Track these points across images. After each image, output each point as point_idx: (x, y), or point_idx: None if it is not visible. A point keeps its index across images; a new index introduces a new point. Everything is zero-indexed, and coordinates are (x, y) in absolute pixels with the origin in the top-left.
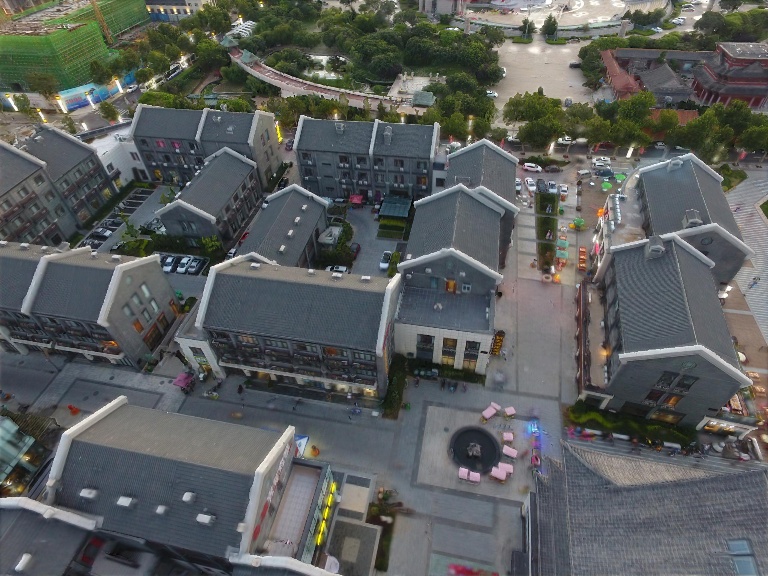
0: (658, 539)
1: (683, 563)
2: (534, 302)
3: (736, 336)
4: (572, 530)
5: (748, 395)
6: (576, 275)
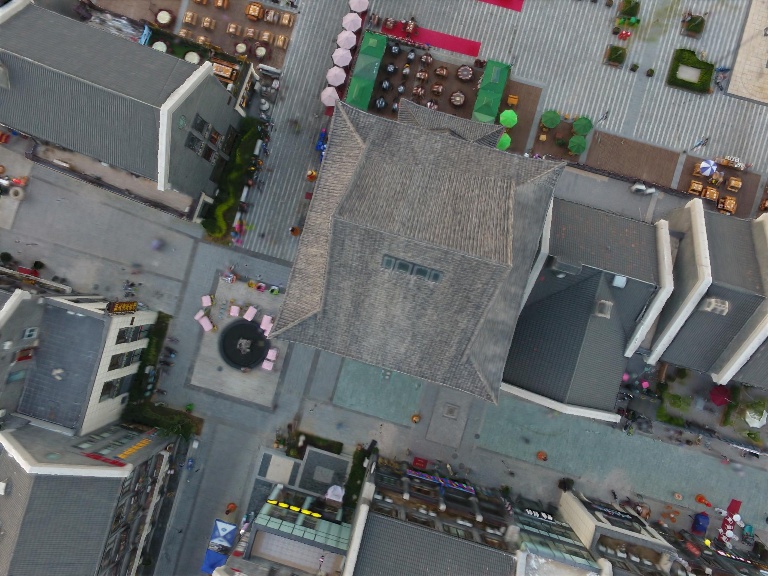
0: (369, 304)
1: (390, 299)
2: (56, 222)
3: (135, 2)
4: (349, 355)
5: (216, 53)
6: (15, 151)
